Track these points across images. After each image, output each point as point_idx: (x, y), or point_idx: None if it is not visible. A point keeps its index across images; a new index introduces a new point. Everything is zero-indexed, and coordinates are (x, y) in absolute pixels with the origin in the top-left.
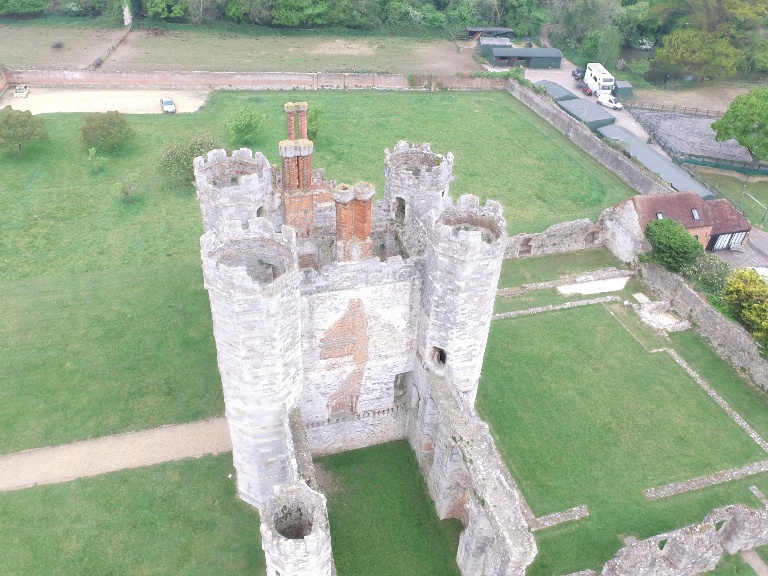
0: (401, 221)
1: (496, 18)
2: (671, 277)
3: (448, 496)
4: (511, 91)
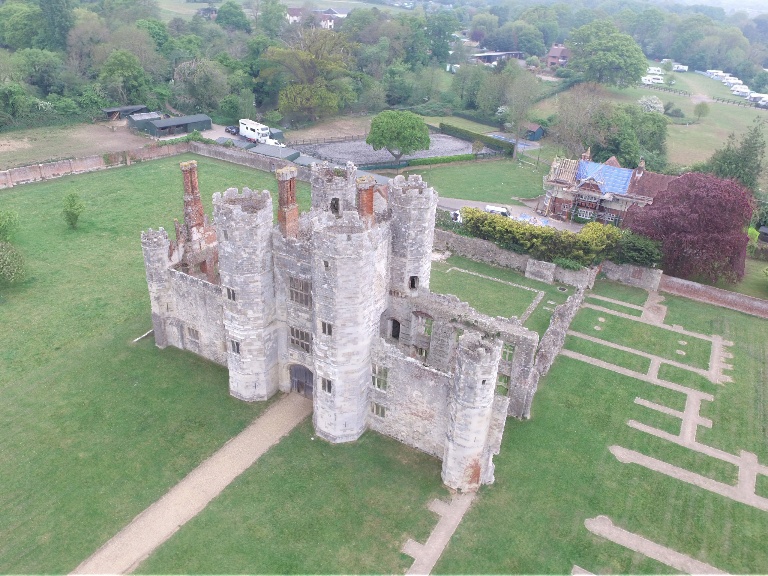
0: (337, 215)
1: (123, 98)
2: None
3: (450, 368)
4: (196, 152)
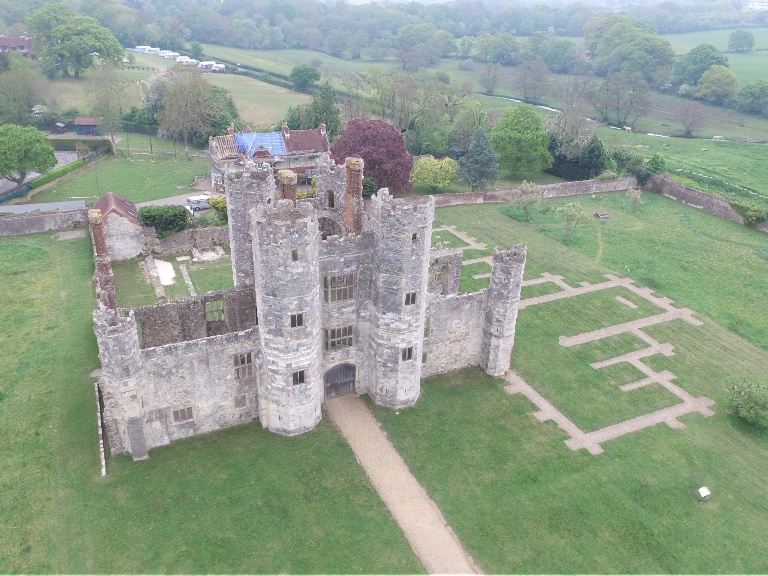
0: None
1: None
2: (183, 234)
3: None
4: None
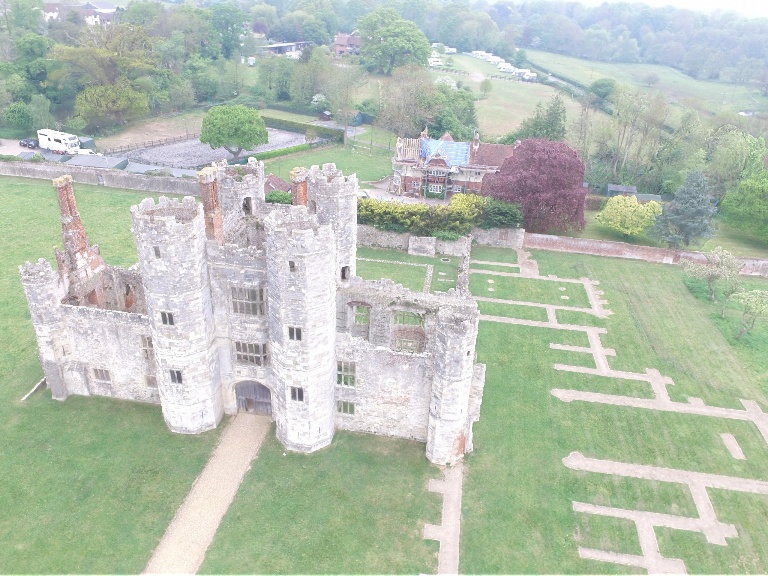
0: (251, 215)
1: None
2: None
3: None
4: None
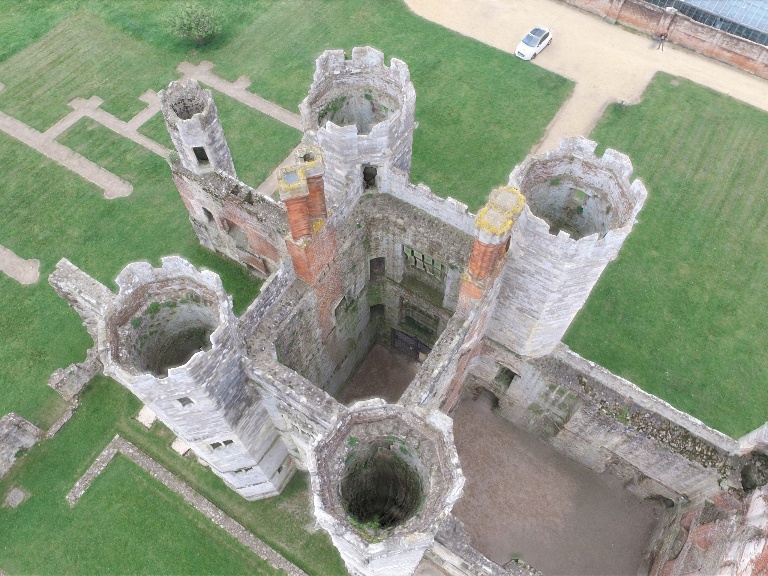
0: None
1: None
2: None
3: None
4: None
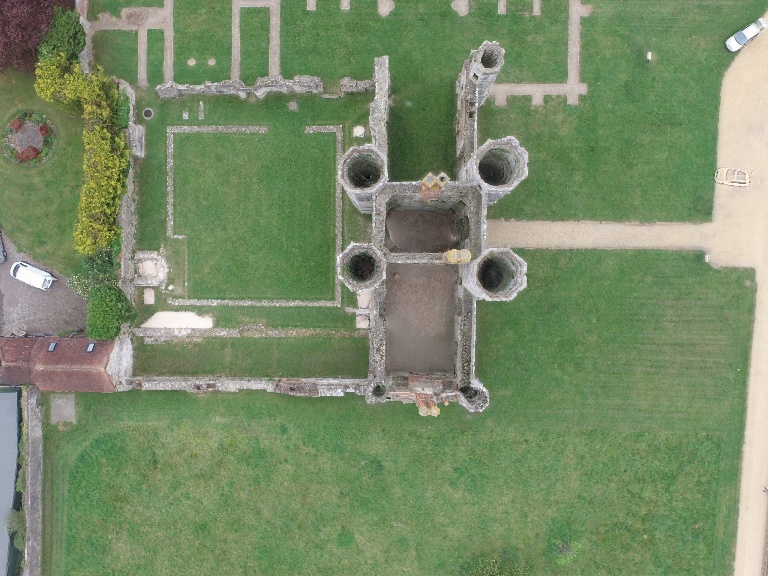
0: None
1: None
2: None
3: None
4: None
